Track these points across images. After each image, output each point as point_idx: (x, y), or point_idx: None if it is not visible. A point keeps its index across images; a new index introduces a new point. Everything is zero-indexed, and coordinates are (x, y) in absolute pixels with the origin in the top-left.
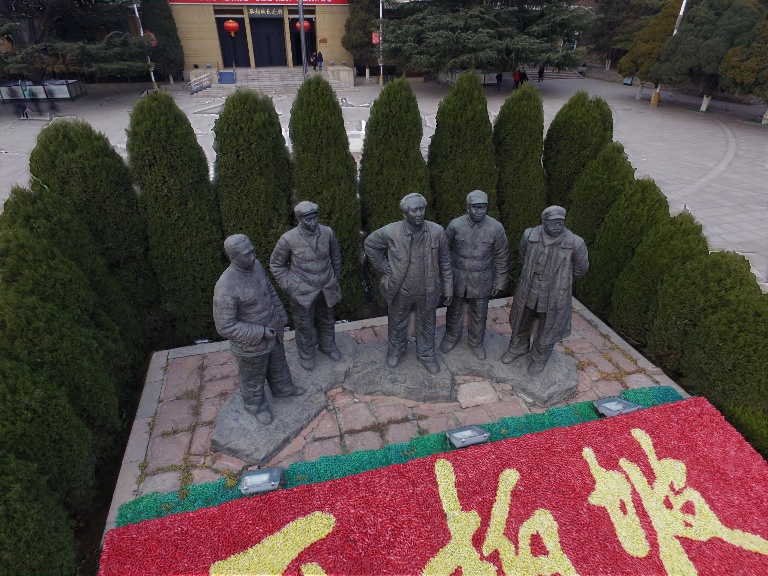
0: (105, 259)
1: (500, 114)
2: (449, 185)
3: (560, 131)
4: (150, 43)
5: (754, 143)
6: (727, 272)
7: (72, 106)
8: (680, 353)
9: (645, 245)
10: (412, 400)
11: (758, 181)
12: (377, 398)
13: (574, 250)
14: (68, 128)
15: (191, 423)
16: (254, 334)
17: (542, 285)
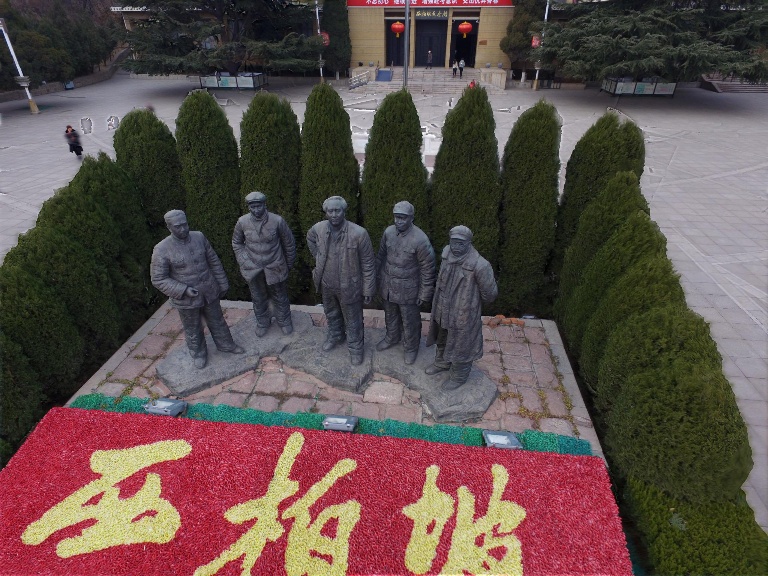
0: (152, 219)
1: None
2: (443, 196)
3: (580, 154)
4: (323, 43)
5: None
6: (669, 331)
7: (251, 95)
8: None
9: (614, 287)
10: (324, 382)
11: None
12: (298, 373)
13: (475, 273)
14: (139, 116)
15: (158, 354)
16: (176, 290)
17: (444, 301)
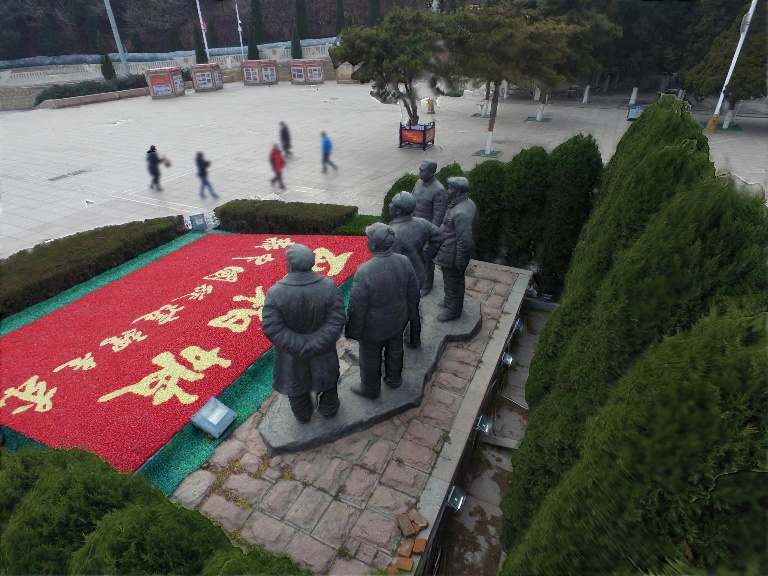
0: None
1: None
2: None
3: None
4: None
5: None
6: None
7: None
8: None
9: None
10: None
11: None
12: None
13: None
14: None
15: None
16: None
17: None
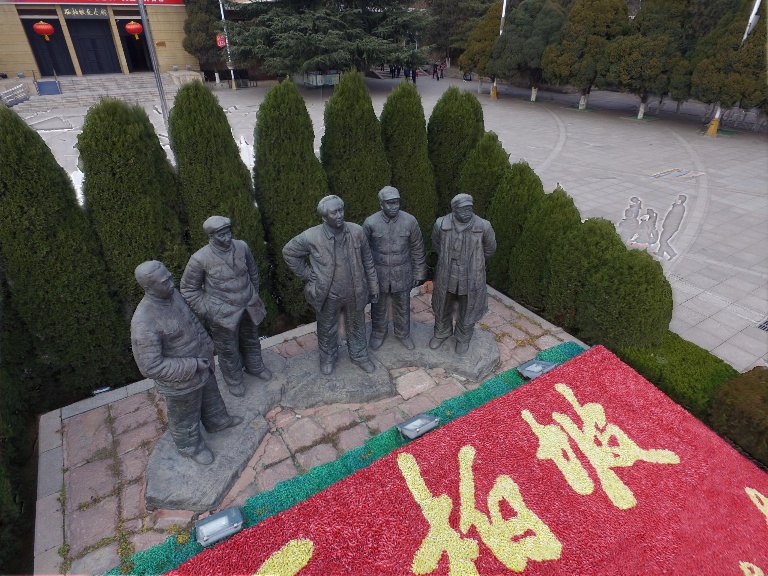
0: None
1: (384, 112)
2: (347, 185)
3: (439, 125)
4: None
5: (577, 126)
6: (601, 236)
7: None
8: (574, 311)
9: (531, 221)
10: (355, 403)
11: (588, 158)
12: (320, 409)
13: (484, 233)
14: None
15: (114, 485)
16: (186, 368)
17: (460, 269)
